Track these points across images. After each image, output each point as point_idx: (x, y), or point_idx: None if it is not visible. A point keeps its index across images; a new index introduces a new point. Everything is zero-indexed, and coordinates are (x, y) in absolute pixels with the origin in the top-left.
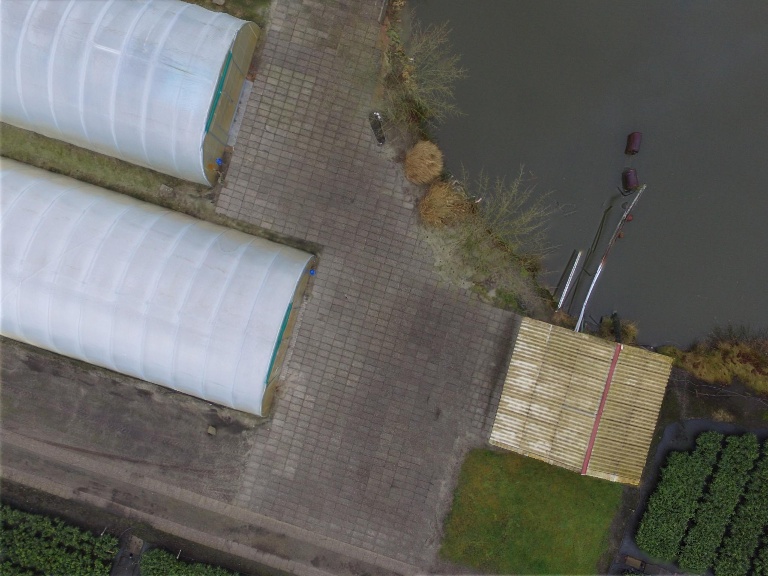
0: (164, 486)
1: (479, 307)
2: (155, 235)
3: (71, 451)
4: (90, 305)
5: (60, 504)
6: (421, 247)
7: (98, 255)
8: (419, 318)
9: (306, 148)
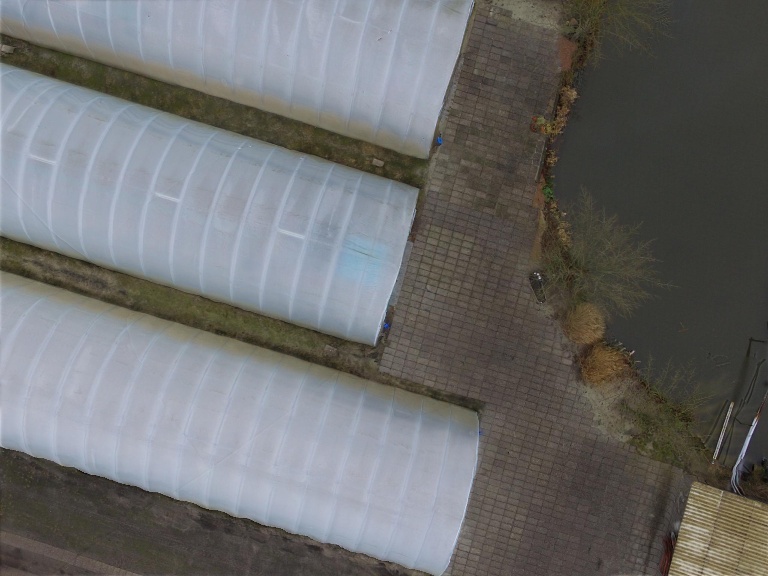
0: None
1: (637, 460)
2: (337, 410)
3: None
4: (282, 486)
5: None
6: (580, 402)
7: (287, 436)
8: (579, 471)
9: (466, 307)
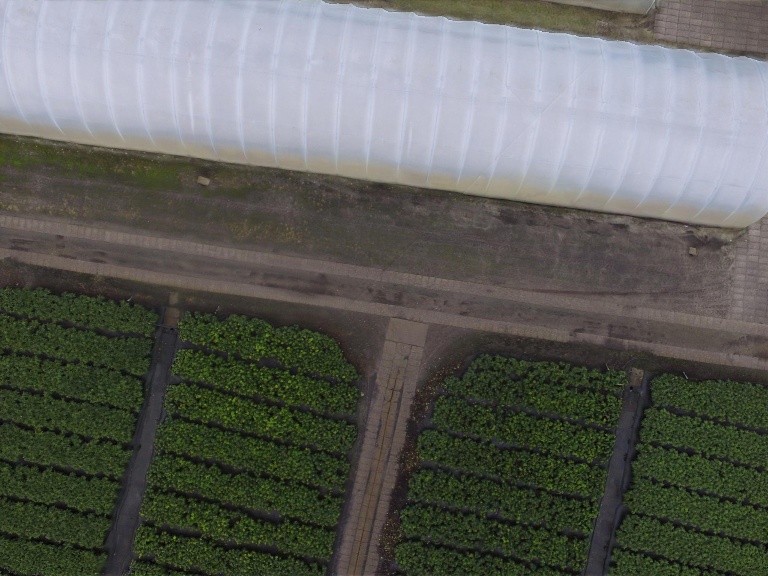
0: (657, 313)
1: None
2: (644, 52)
3: (561, 295)
4: (612, 124)
5: (559, 349)
6: None
7: (607, 75)
8: None
9: None
